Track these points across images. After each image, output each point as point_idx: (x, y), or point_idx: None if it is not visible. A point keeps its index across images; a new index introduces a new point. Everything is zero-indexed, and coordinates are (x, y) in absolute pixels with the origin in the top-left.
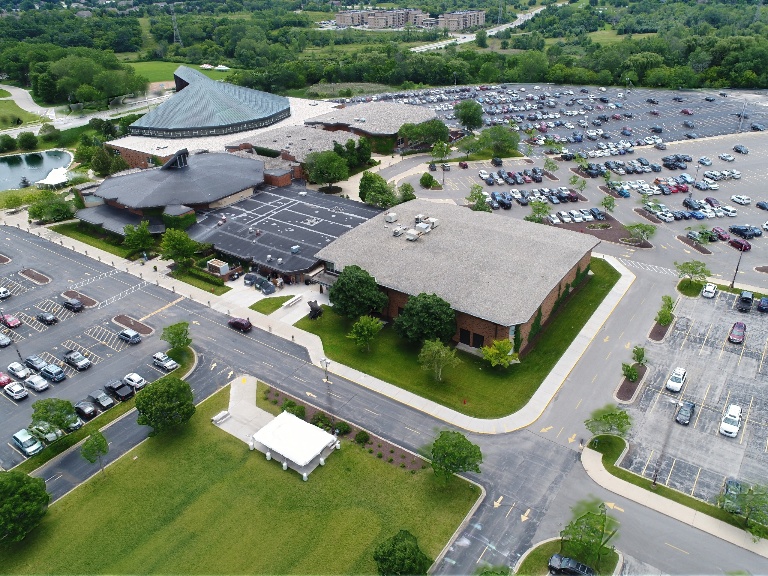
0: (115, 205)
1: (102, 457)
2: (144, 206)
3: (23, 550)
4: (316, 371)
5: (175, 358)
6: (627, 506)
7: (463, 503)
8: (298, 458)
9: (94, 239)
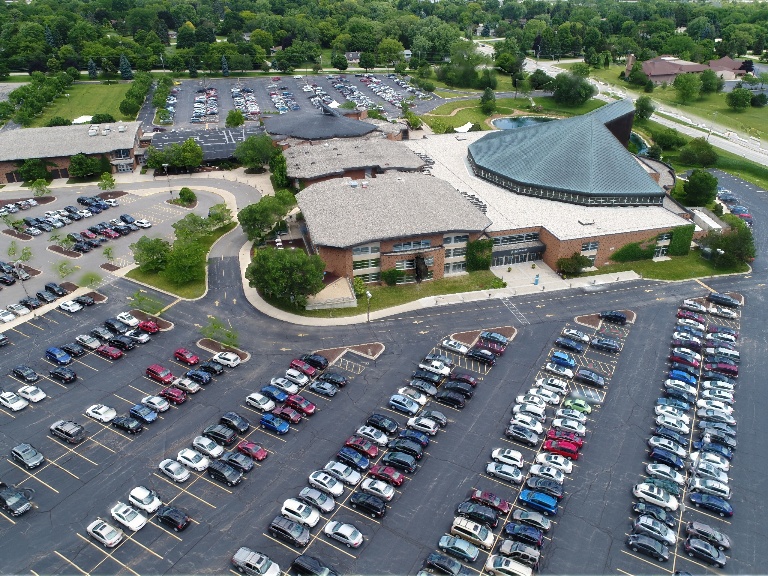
0: None
1: None
2: None
3: None
4: None
5: None
6: None
7: None
8: None
9: None
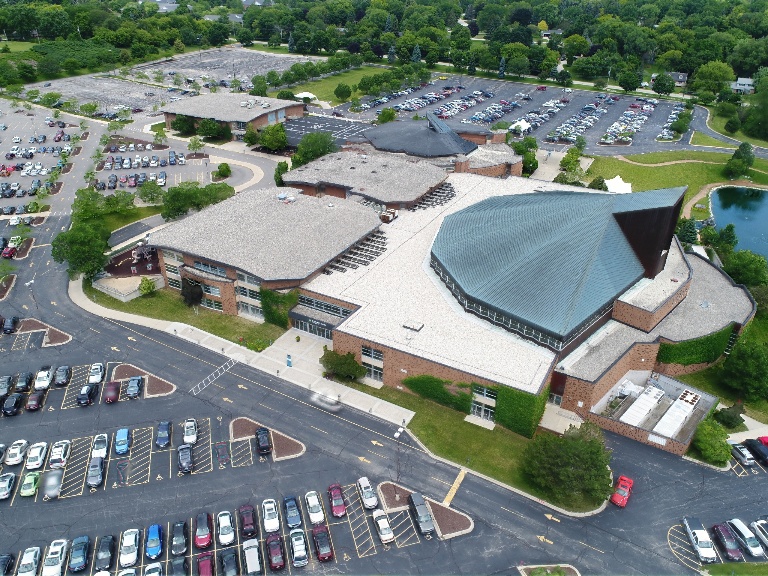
0: None
1: None
2: None
3: (362, 93)
4: None
5: None
6: None
7: None
8: None
9: None
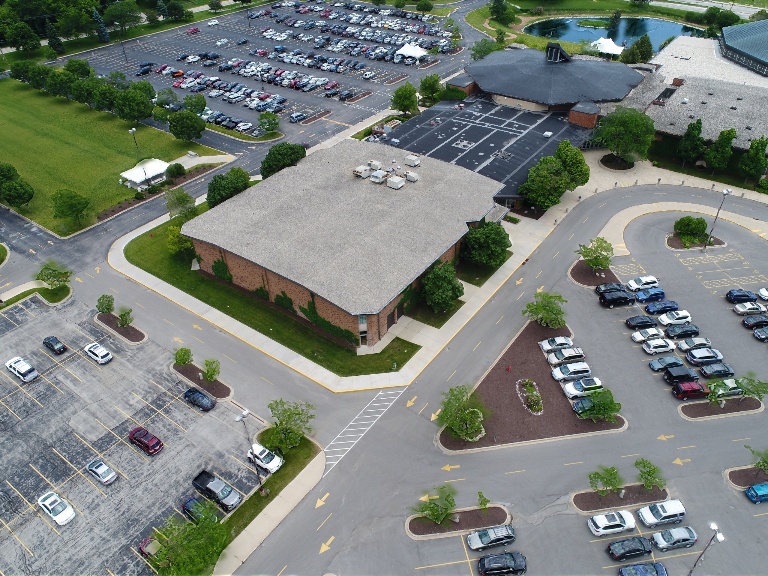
0: None
1: (161, 123)
2: (467, 70)
3: (128, 127)
4: None
5: None
6: (1, 290)
7: (59, 229)
8: (126, 172)
9: None
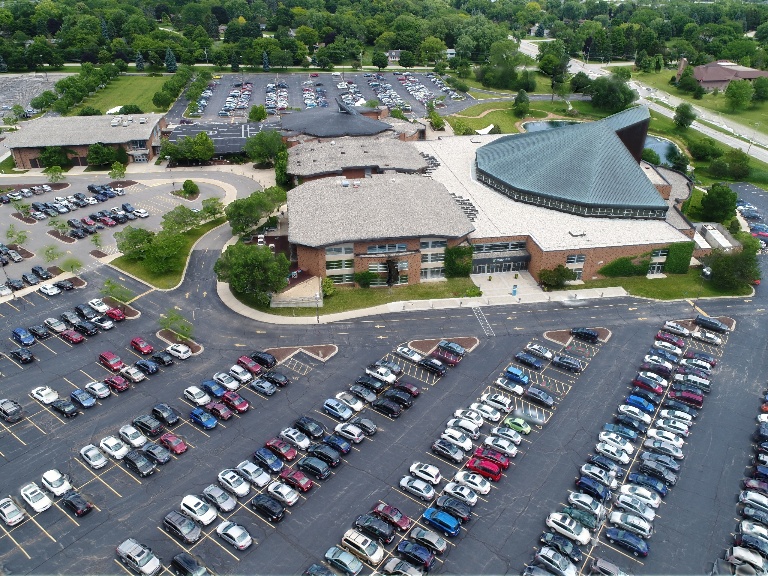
0: None
1: None
2: None
3: None
4: None
5: None
6: None
7: None
8: None
9: None
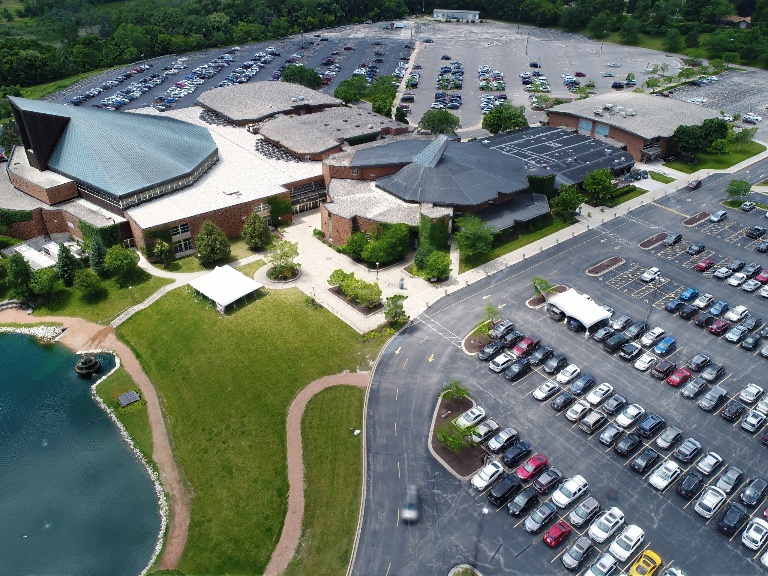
0: (478, 209)
1: None
2: (527, 182)
3: None
4: (739, 173)
5: (739, 205)
6: None
7: None
8: None
9: (519, 240)
